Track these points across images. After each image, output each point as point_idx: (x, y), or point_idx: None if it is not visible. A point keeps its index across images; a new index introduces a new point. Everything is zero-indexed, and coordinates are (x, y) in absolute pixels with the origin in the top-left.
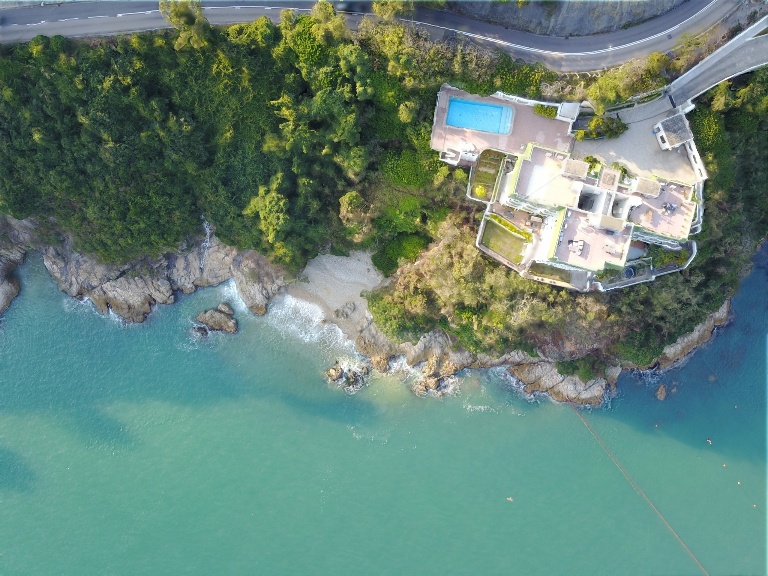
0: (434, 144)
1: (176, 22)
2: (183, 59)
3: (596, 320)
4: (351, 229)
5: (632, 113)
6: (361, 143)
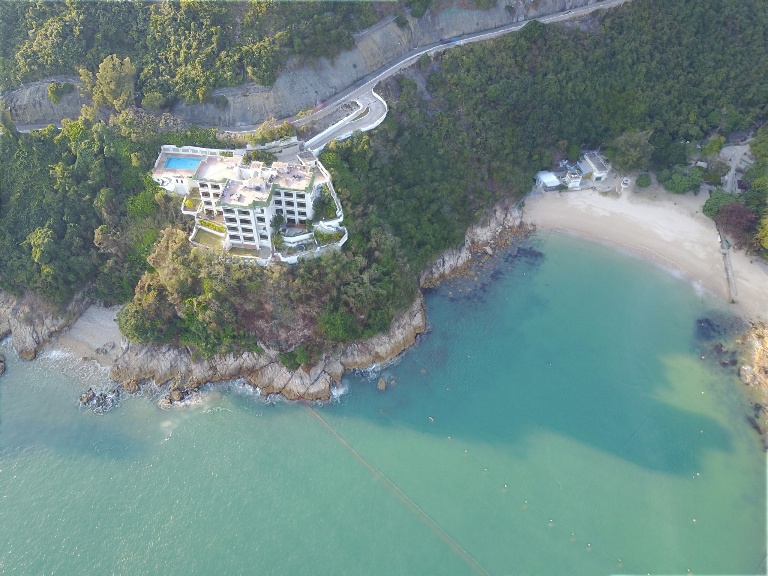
0: (154, 176)
1: None
2: None
3: (282, 280)
4: None
5: (284, 158)
6: None
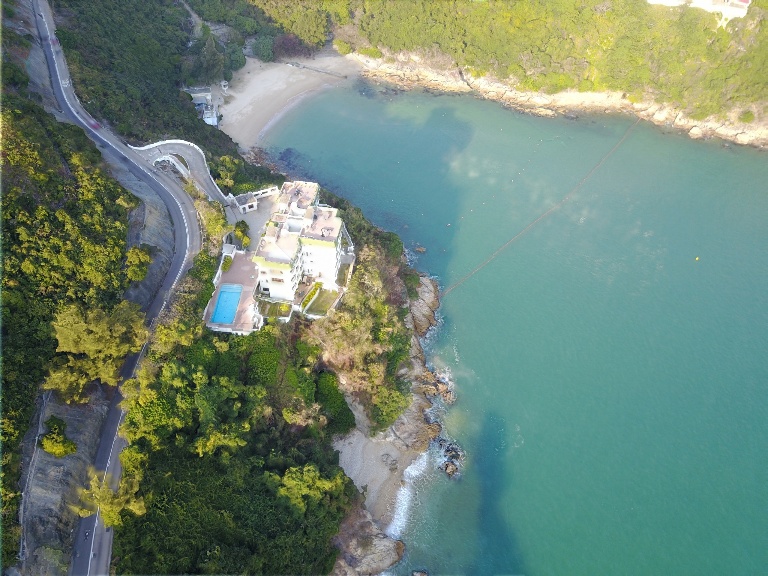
0: (247, 330)
1: (124, 489)
2: (148, 539)
3: None
4: (315, 431)
5: None
6: (240, 400)
